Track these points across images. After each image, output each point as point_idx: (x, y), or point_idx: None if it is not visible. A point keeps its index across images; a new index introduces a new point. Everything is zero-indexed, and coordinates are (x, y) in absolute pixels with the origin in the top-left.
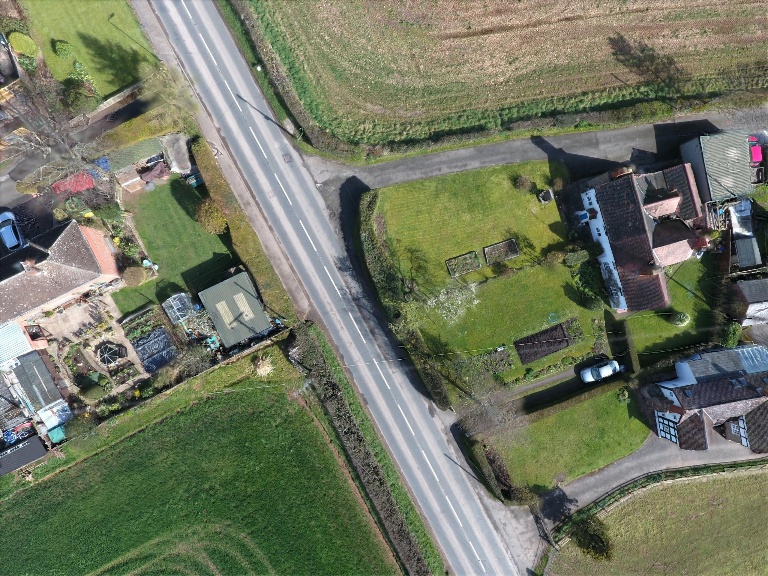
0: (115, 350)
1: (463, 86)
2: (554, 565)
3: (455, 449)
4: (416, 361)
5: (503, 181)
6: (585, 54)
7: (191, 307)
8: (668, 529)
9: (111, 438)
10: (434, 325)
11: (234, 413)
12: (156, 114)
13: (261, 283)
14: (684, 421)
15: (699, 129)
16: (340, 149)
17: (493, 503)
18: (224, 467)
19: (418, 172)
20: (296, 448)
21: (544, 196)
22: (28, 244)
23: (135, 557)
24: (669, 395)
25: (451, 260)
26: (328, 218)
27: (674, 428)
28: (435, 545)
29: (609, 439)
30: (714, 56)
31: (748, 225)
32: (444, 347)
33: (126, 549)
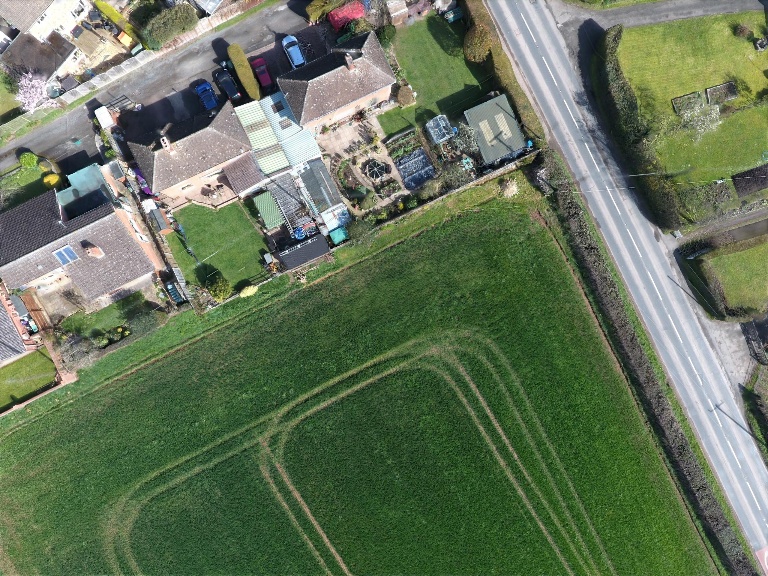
0: (382, 166)
1: None
2: (763, 382)
3: (677, 272)
4: (655, 181)
5: (724, 28)
6: None
7: None
8: None
9: (374, 248)
10: (661, 157)
11: (483, 230)
12: None
13: (520, 104)
14: None
15: None
16: None
17: (710, 323)
18: (474, 278)
19: (648, 17)
20: (538, 264)
21: (761, 43)
22: (331, 51)
23: (395, 356)
24: None
25: (677, 99)
26: (568, 56)
27: None
28: (658, 358)
29: None
30: None
31: None
32: None
33: (388, 348)
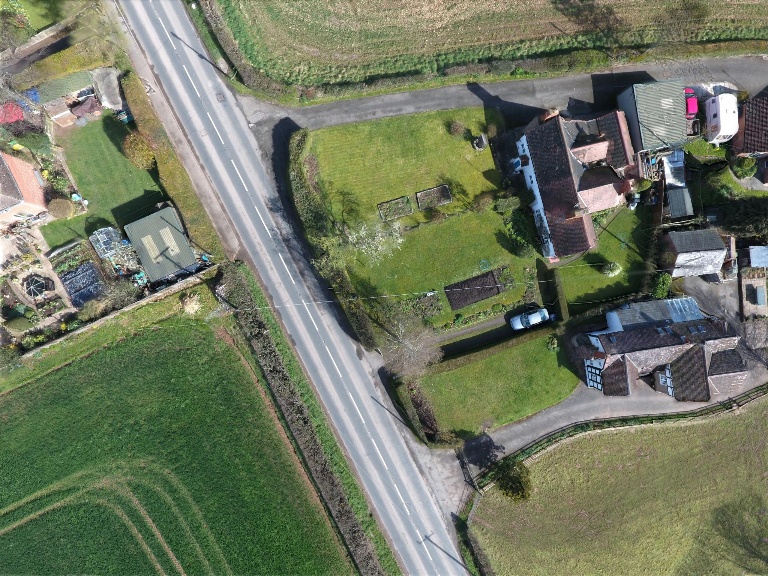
0: (42, 283)
1: (400, 31)
2: (479, 510)
3: (382, 392)
4: (341, 300)
5: (438, 127)
6: (524, 2)
7: (117, 240)
8: (594, 478)
9: (37, 371)
10: (364, 268)
11: (161, 350)
12: (85, 46)
13: (187, 218)
14: (608, 367)
15: (637, 80)
16: (272, 88)
17: (419, 447)
18: (149, 403)
19: (352, 115)
20: (222, 386)
21: (478, 143)
22: None
23: (58, 489)
24: (595, 342)
25: (383, 204)
26: (260, 158)
27: (599, 375)
28: (360, 487)
29: (537, 387)
30: (654, 8)
31: (681, 176)
32: (374, 290)
33: (49, 481)
